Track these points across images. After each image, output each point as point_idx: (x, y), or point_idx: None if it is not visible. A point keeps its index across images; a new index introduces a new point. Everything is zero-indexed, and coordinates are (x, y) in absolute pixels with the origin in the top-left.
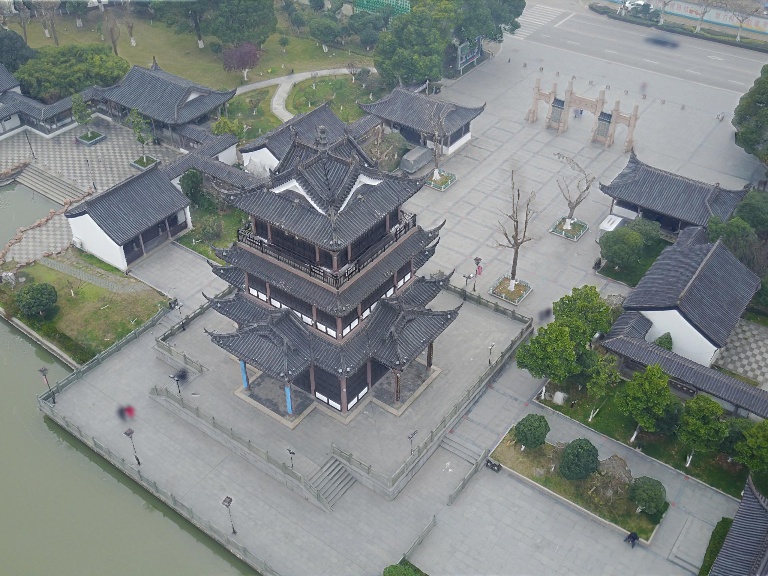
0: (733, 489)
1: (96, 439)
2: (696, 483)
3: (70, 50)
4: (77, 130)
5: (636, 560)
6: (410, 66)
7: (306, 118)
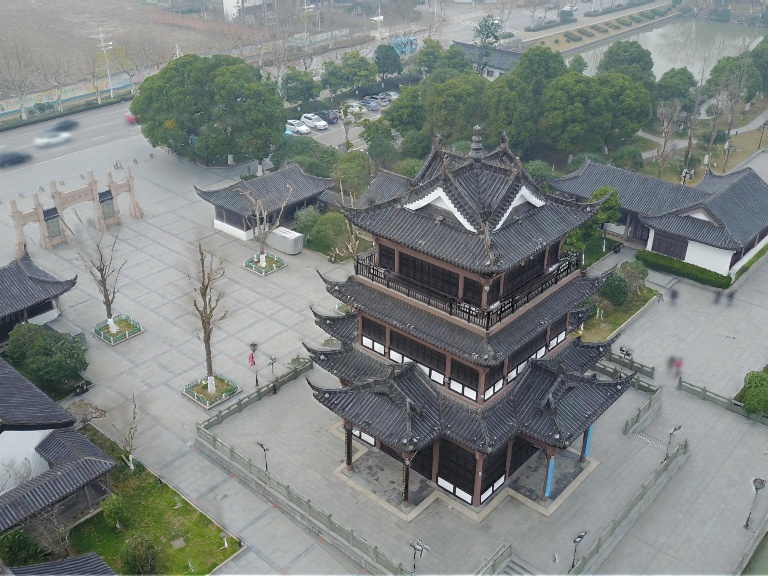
0: (600, 253)
1: None
2: (597, 265)
3: None
4: None
5: (675, 301)
6: None
7: None
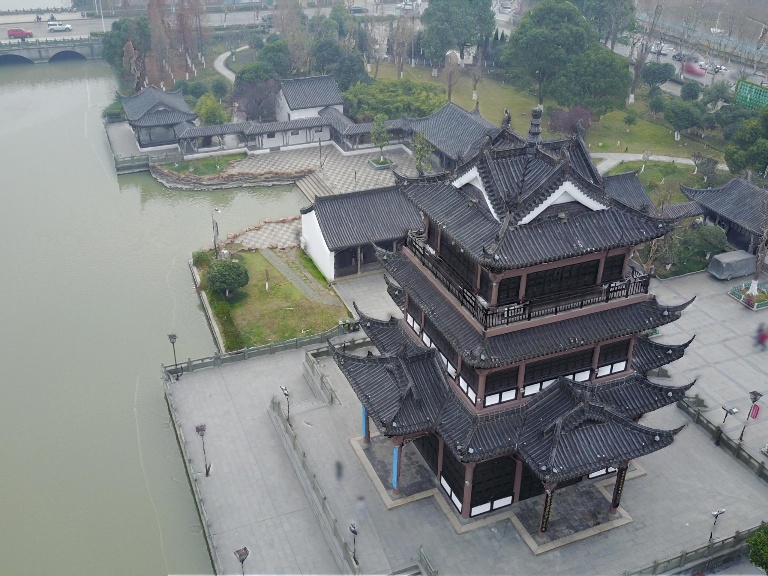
0: None
1: (187, 430)
2: None
3: (403, 83)
4: (375, 155)
5: None
6: None
7: None
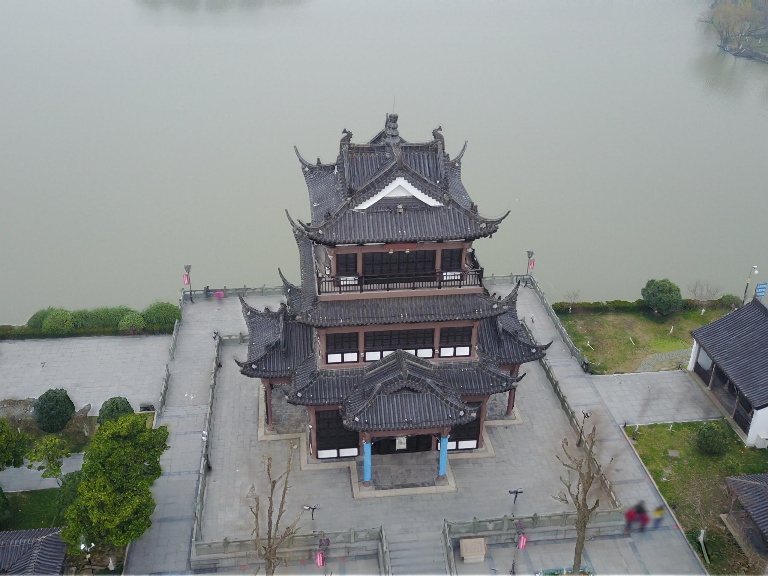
0: None
1: None
2: None
3: None
4: None
5: None
6: None
7: None
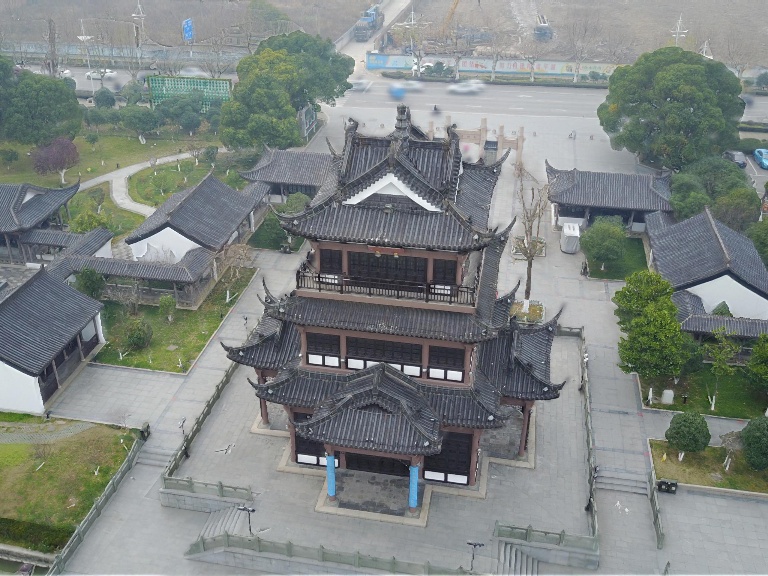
0: None
1: None
2: None
3: None
4: None
5: None
6: (271, 131)
7: (198, 190)
